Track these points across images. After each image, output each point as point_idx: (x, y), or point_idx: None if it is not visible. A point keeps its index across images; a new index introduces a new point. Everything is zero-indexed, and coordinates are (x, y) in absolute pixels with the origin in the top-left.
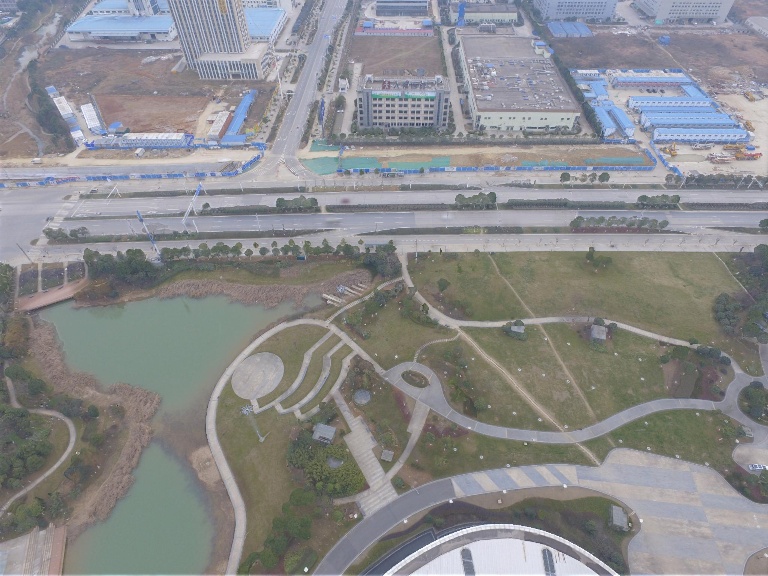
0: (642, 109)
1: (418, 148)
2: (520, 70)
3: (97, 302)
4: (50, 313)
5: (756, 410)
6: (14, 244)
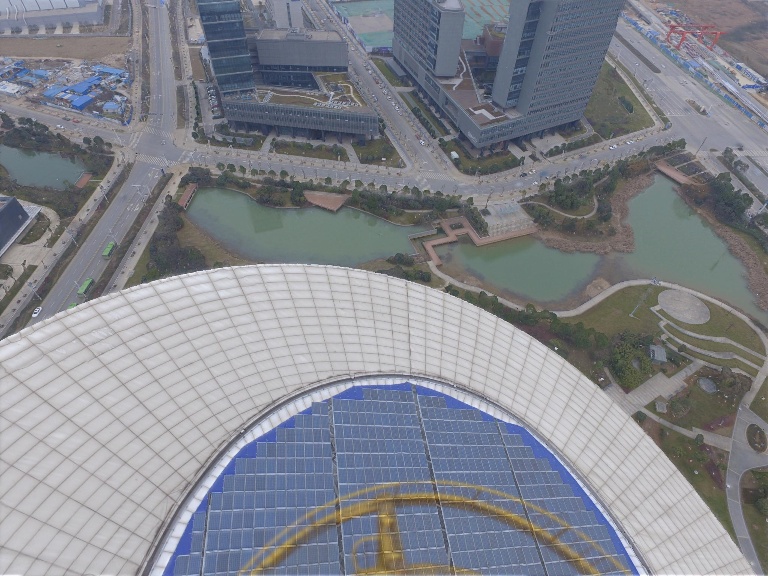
0: None
1: None
2: None
3: (686, 197)
4: (661, 181)
5: None
6: None
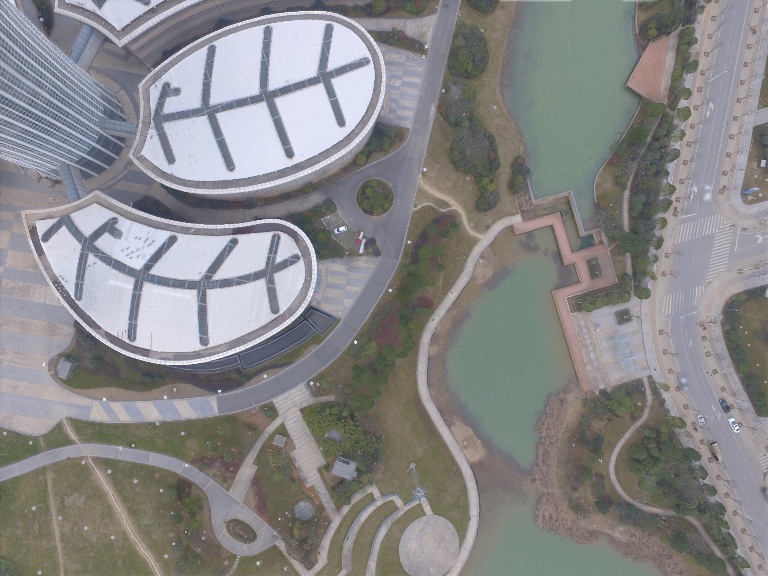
0: None
1: None
2: None
3: None
4: None
5: None
6: None
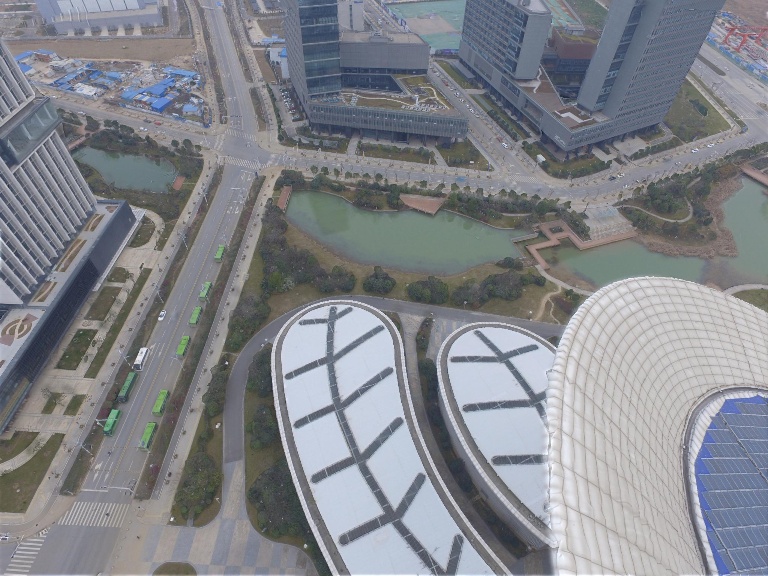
0: None
1: None
2: None
3: None
4: (747, 184)
5: None
6: None
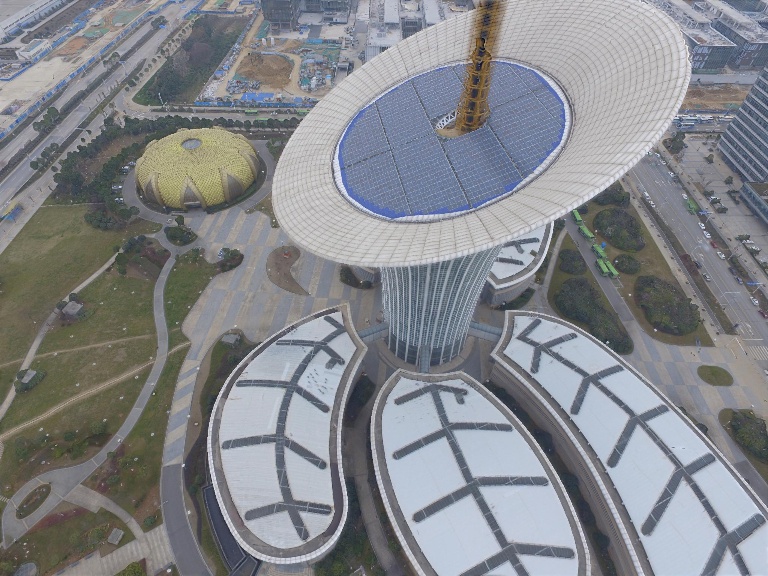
0: None
1: None
2: None
3: None
4: None
5: (184, 237)
6: None
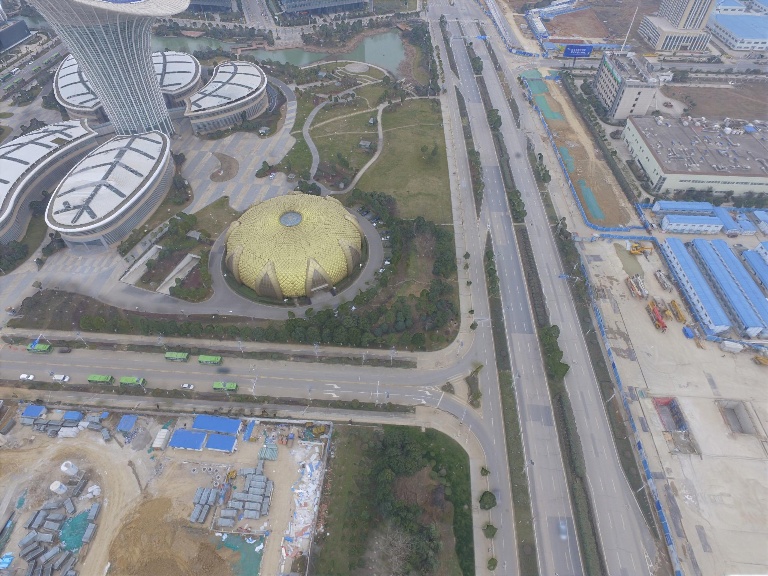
0: (746, 251)
1: (571, 107)
2: (760, 150)
3: None
4: None
5: None
6: (438, 16)
